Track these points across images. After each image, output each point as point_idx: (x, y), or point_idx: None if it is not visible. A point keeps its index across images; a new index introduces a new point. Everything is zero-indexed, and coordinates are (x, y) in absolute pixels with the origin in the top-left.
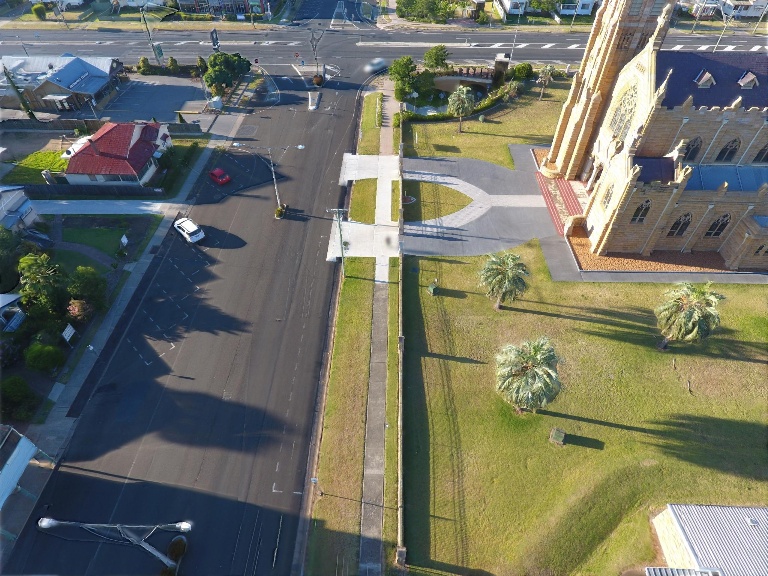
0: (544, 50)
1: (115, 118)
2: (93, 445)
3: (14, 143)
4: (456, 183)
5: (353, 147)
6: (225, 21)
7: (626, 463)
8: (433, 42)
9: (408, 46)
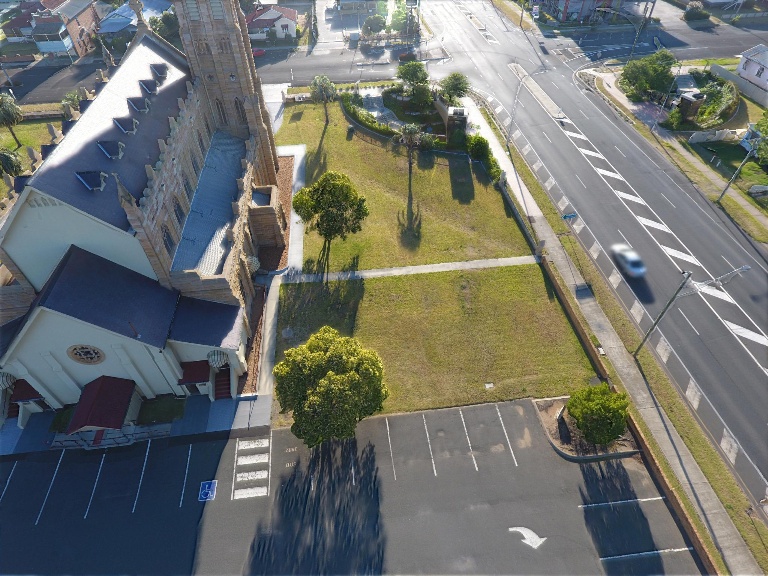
0: (587, 170)
1: (331, 19)
2: None
3: (301, 9)
4: None
5: (301, 86)
6: (529, 14)
7: None
8: (550, 97)
9: (526, 86)
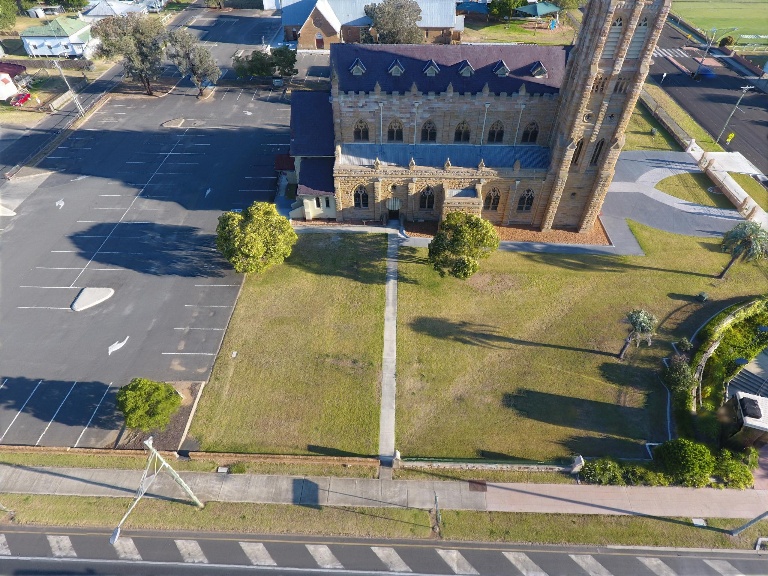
0: None
1: None
2: (763, 97)
3: None
4: (680, 204)
5: None
6: None
7: None
8: None
9: None
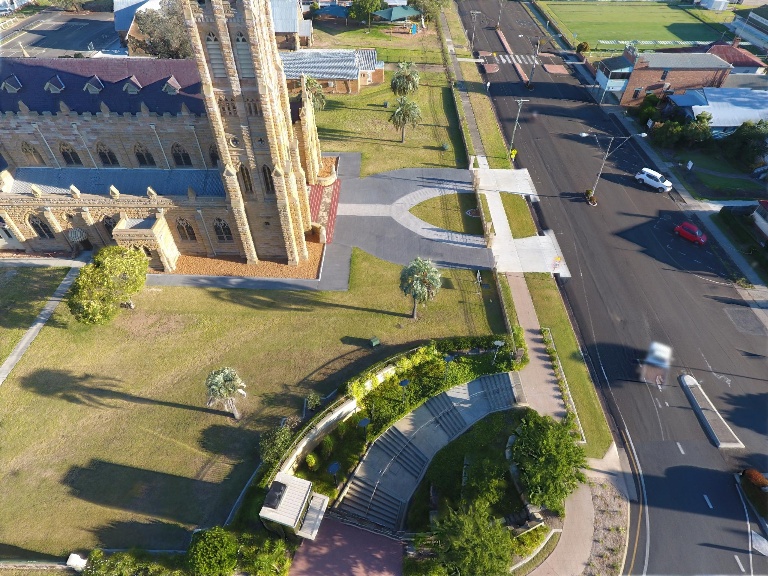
0: None
1: None
2: None
3: None
4: (425, 230)
5: (565, 290)
6: None
7: (361, 100)
8: None
9: None
